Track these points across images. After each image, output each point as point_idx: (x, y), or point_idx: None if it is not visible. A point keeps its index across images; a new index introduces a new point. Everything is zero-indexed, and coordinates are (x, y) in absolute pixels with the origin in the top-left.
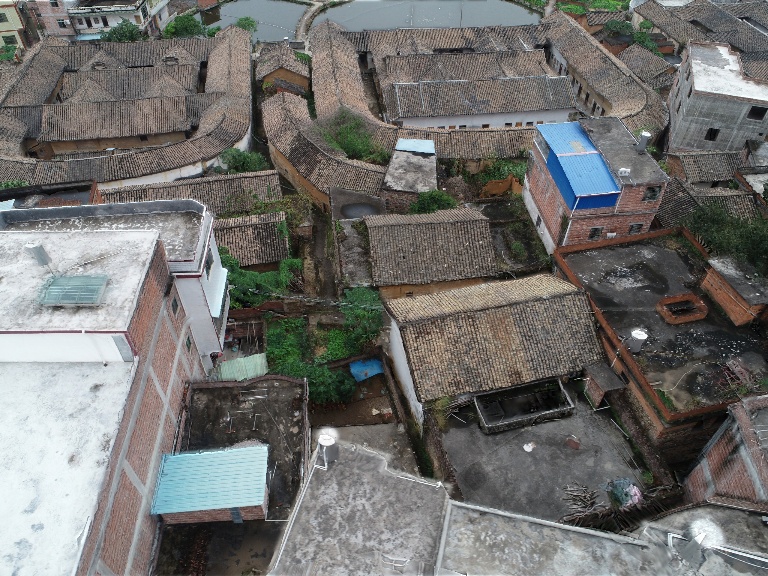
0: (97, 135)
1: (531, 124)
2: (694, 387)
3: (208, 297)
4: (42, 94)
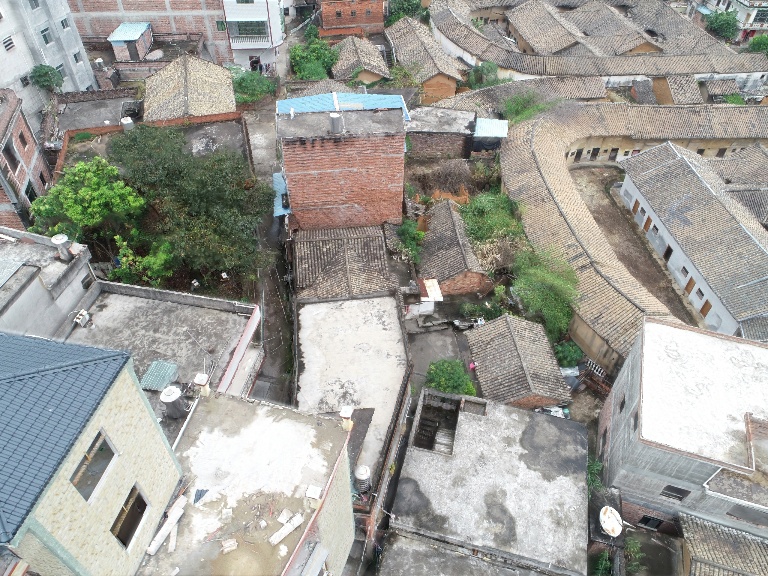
0: (519, 28)
1: (702, 296)
2: (87, 155)
3: (229, 7)
4: (568, 2)
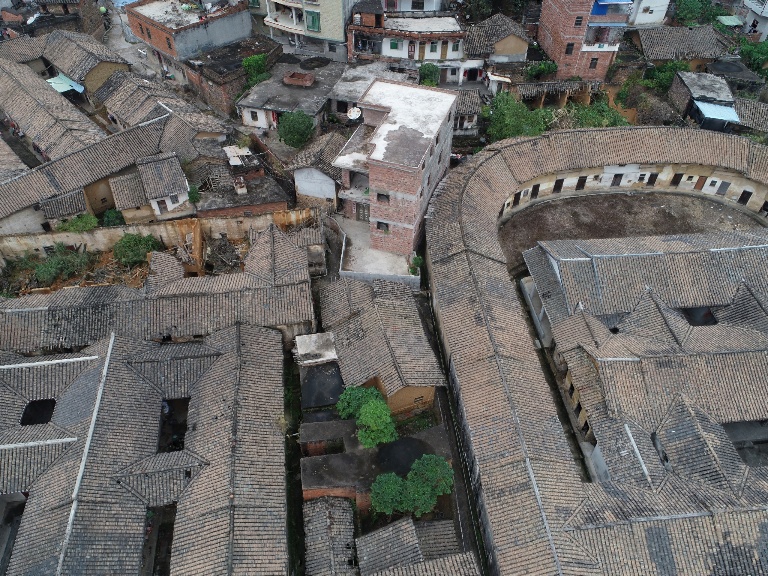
0: None
1: None
2: None
3: None
4: None
